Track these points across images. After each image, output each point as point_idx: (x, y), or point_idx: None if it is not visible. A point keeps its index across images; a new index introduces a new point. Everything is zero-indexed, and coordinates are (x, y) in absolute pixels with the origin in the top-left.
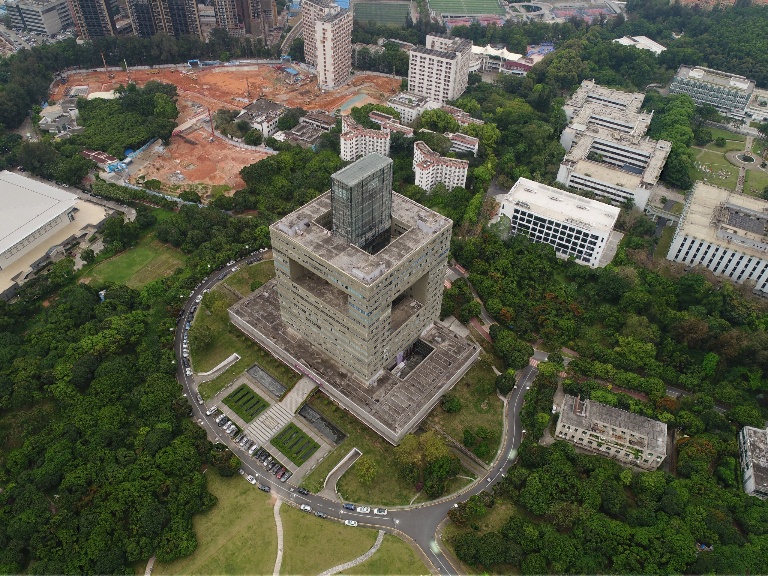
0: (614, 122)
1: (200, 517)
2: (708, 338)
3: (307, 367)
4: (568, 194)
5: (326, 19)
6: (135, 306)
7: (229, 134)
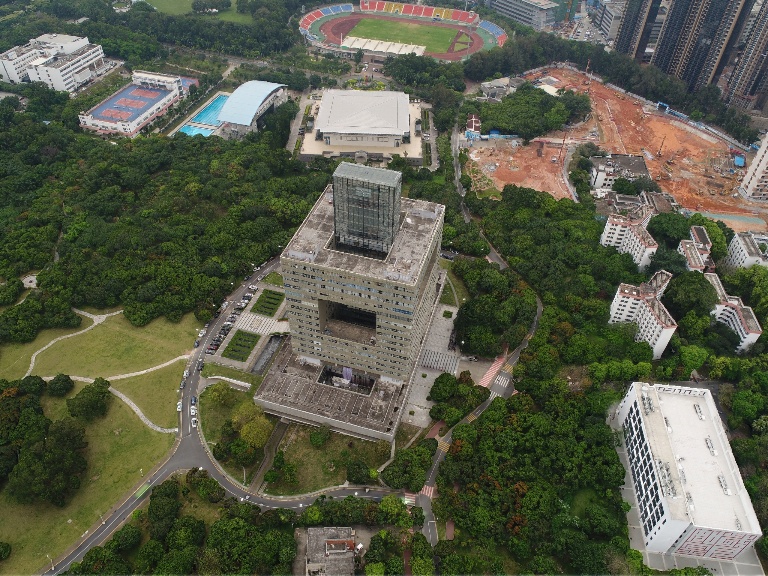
0: None
1: (165, 319)
2: None
3: None
4: (730, 455)
5: None
6: None
7: None
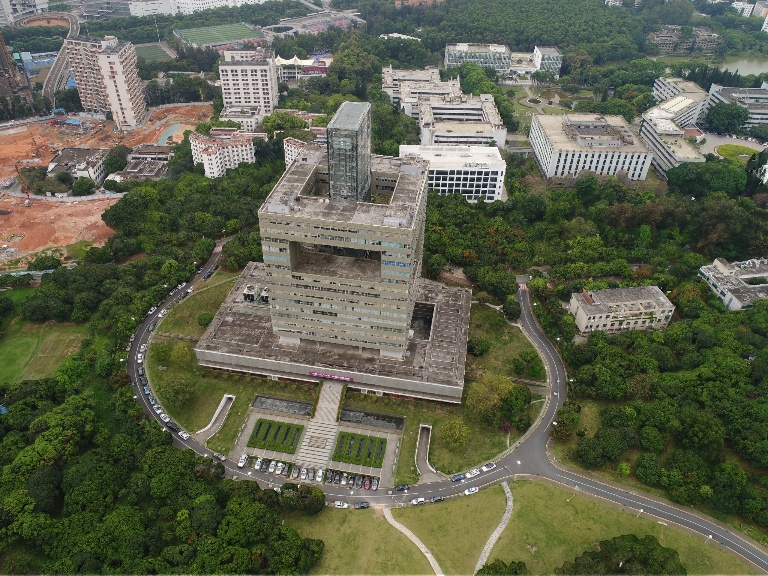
0: (432, 92)
1: (315, 570)
2: (634, 215)
3: (328, 367)
4: (448, 148)
5: (109, 51)
6: (58, 397)
7: (48, 192)
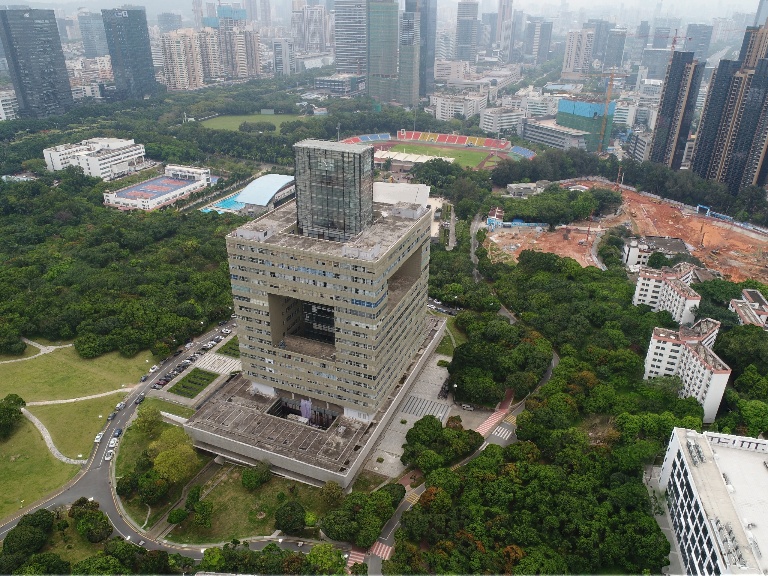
0: None
1: (118, 354)
2: None
3: None
4: None
5: None
6: None
7: None
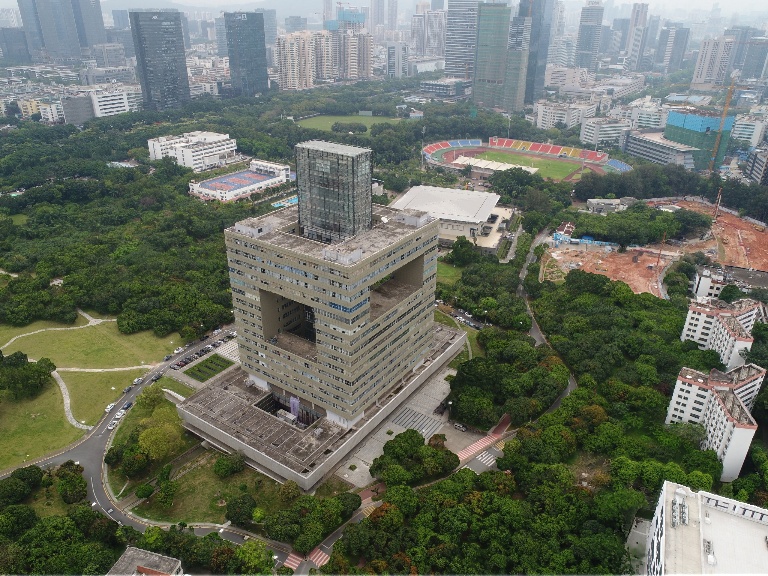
0: None
1: (152, 333)
2: None
3: None
4: None
5: None
6: None
7: None
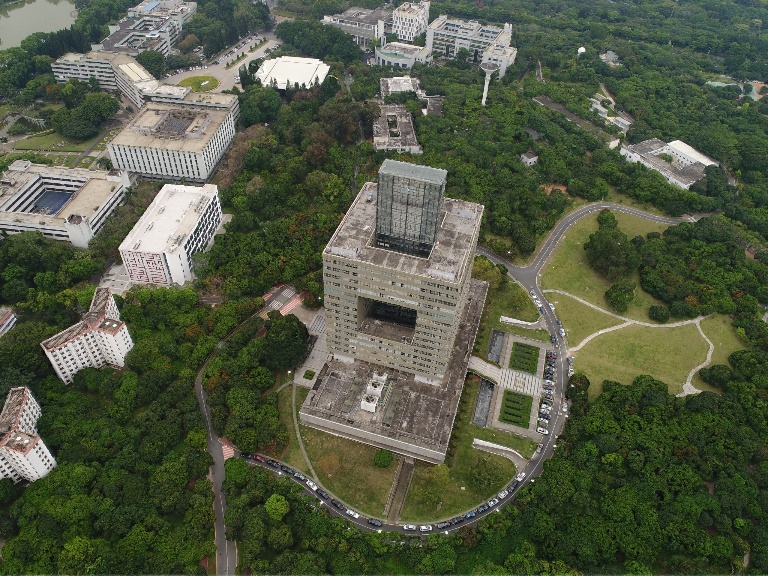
0: None
1: None
2: None
3: (470, 353)
4: (145, 216)
5: None
6: None
7: None
